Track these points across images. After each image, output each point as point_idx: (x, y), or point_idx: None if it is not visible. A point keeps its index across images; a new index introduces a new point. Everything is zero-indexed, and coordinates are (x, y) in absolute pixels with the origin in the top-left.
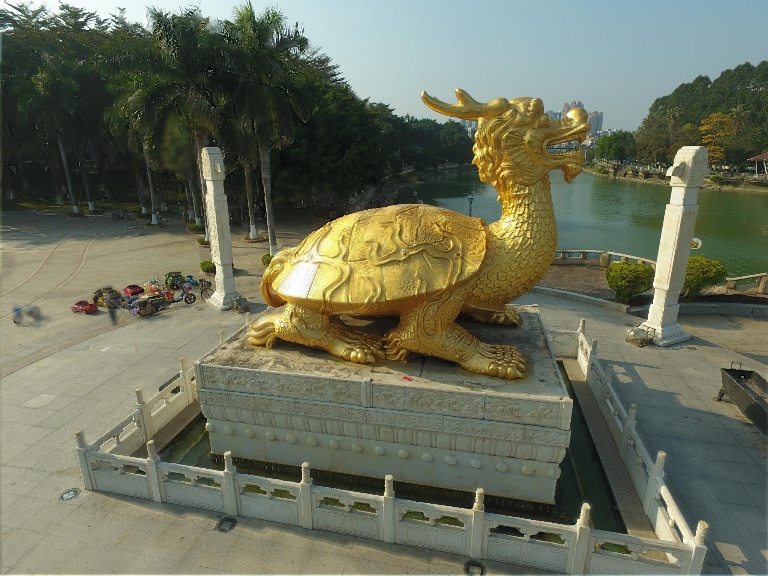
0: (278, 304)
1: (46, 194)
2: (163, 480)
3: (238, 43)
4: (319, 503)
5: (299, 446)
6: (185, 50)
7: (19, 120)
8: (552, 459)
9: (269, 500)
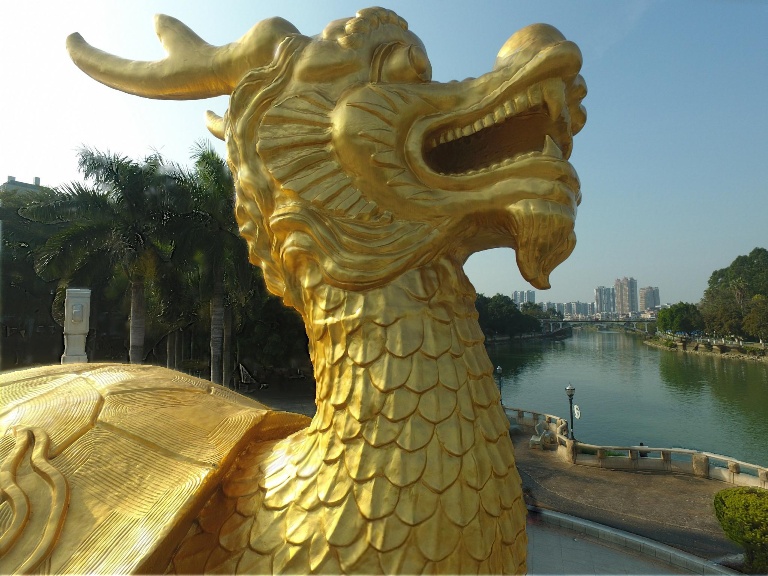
0: None
1: (43, 359)
2: None
3: (196, 187)
4: None
5: None
6: (129, 193)
7: (37, 286)
8: None
9: None
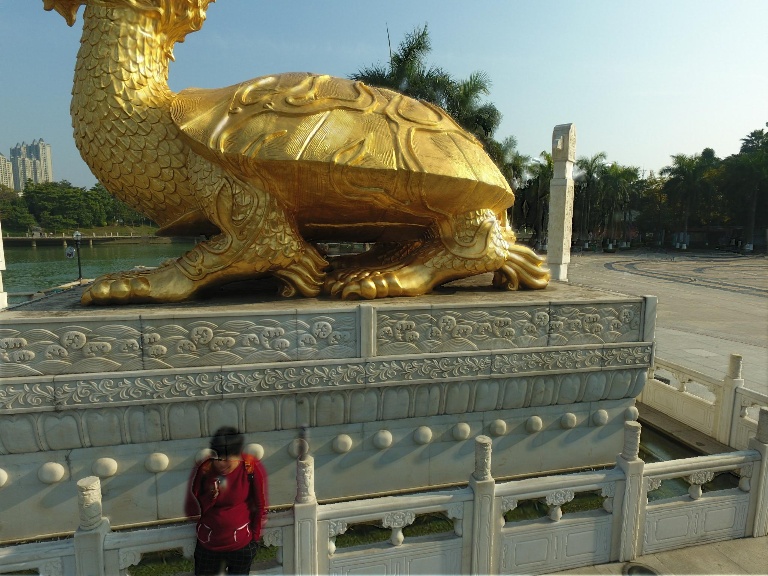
0: None
1: None
2: None
3: None
4: None
5: None
6: None
7: None
8: None
9: None
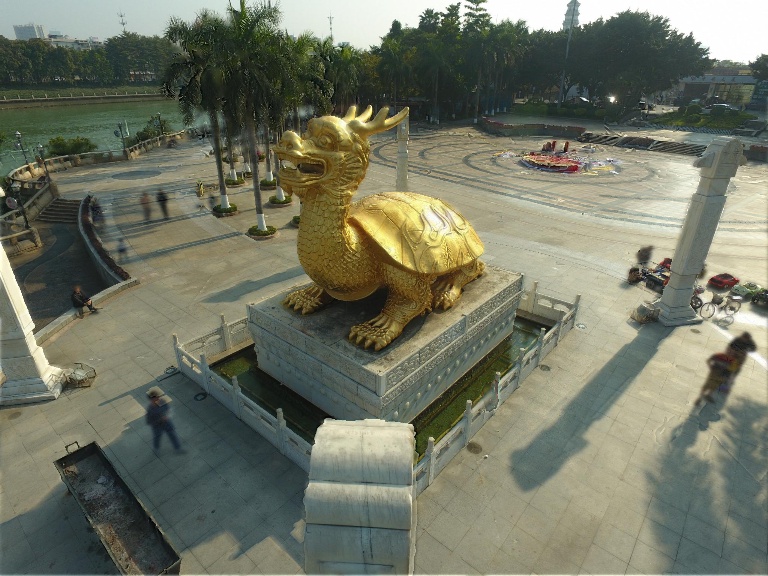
0: None
1: None
2: None
3: None
4: None
5: None
6: None
7: None
8: None
9: None
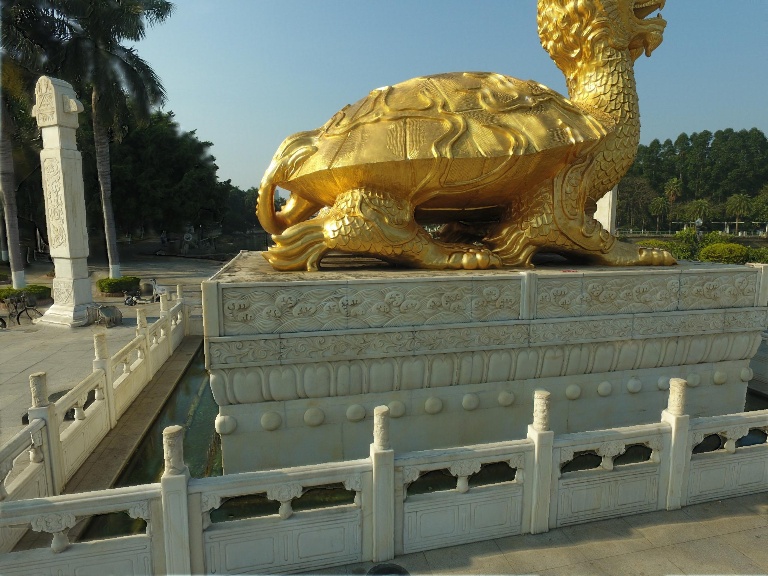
0: (280, 229)
1: None
2: (202, 527)
3: None
4: (559, 471)
5: (408, 420)
6: None
7: None
8: (745, 353)
9: (467, 494)
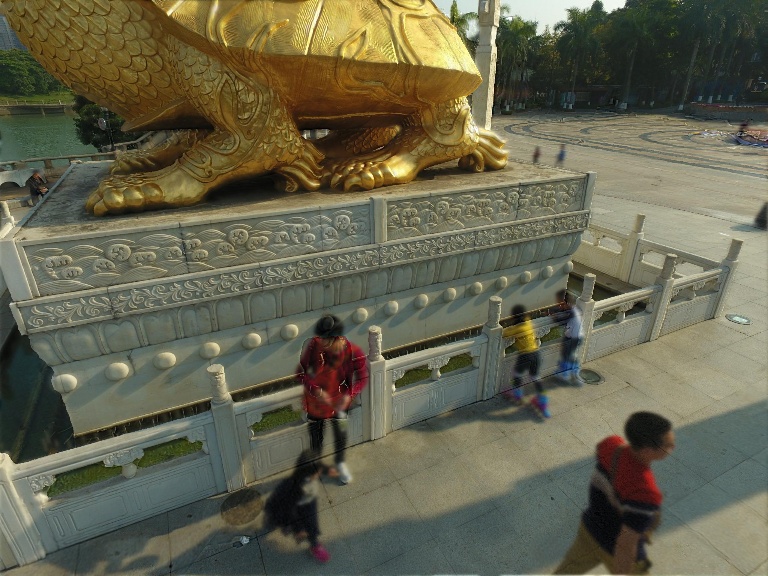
0: None
1: None
2: None
3: None
4: None
5: None
6: None
7: None
8: None
9: None
